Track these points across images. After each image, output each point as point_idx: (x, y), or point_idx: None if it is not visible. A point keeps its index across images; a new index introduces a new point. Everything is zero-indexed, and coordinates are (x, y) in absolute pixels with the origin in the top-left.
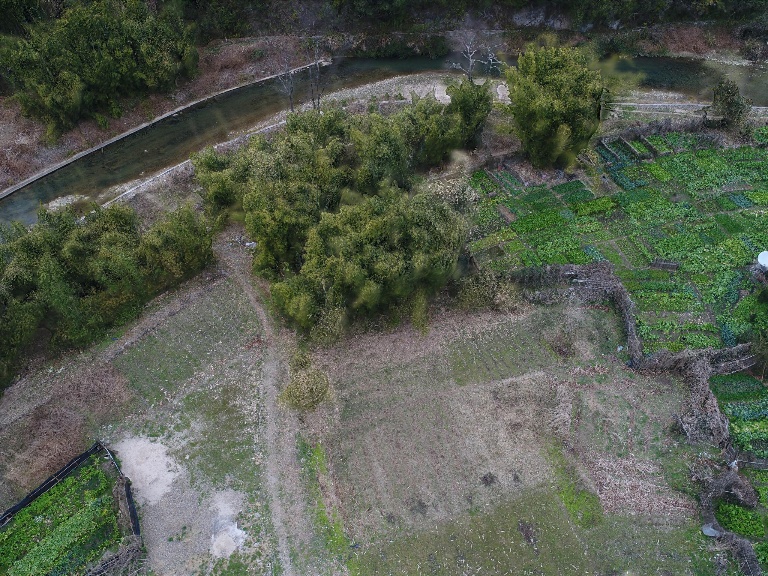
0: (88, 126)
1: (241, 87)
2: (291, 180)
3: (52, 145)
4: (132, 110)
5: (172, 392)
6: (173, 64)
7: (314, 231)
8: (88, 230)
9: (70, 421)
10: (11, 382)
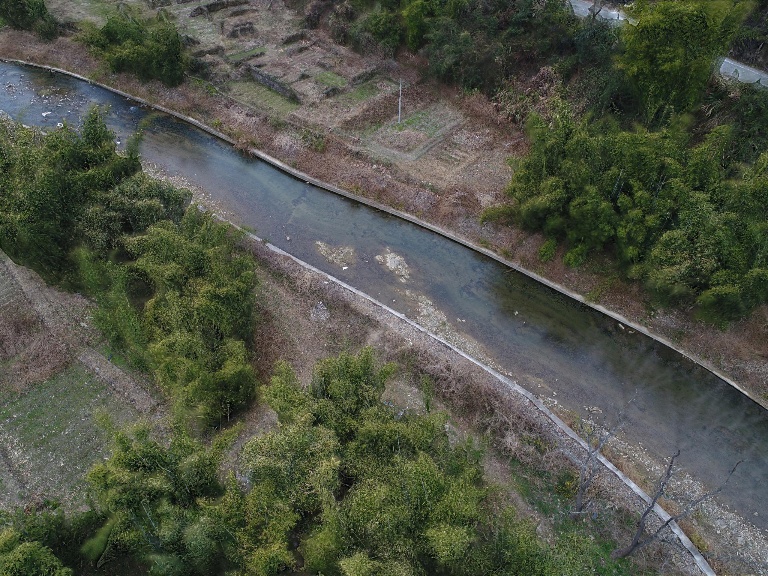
0: (536, 242)
1: (755, 401)
2: (248, 495)
3: (490, 224)
4: (592, 274)
5: (4, 426)
6: (684, 283)
7: (7, 536)
8: (169, 276)
9: (9, 348)
10: (89, 295)
